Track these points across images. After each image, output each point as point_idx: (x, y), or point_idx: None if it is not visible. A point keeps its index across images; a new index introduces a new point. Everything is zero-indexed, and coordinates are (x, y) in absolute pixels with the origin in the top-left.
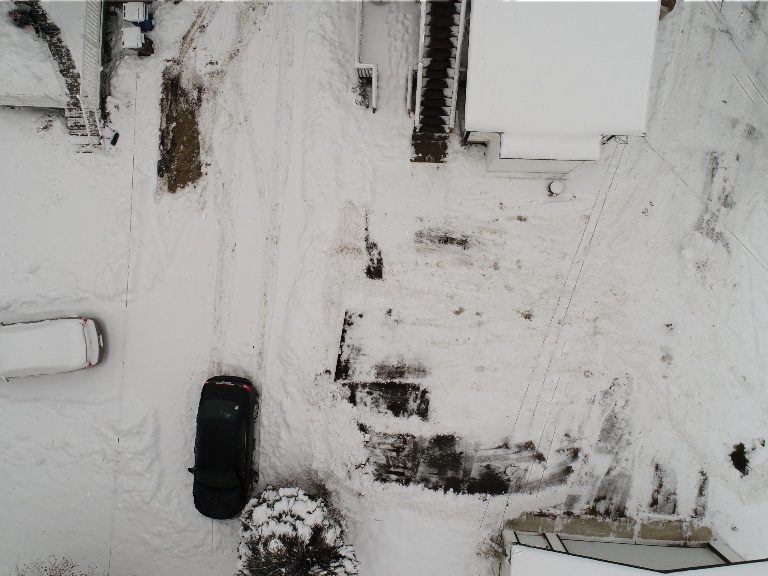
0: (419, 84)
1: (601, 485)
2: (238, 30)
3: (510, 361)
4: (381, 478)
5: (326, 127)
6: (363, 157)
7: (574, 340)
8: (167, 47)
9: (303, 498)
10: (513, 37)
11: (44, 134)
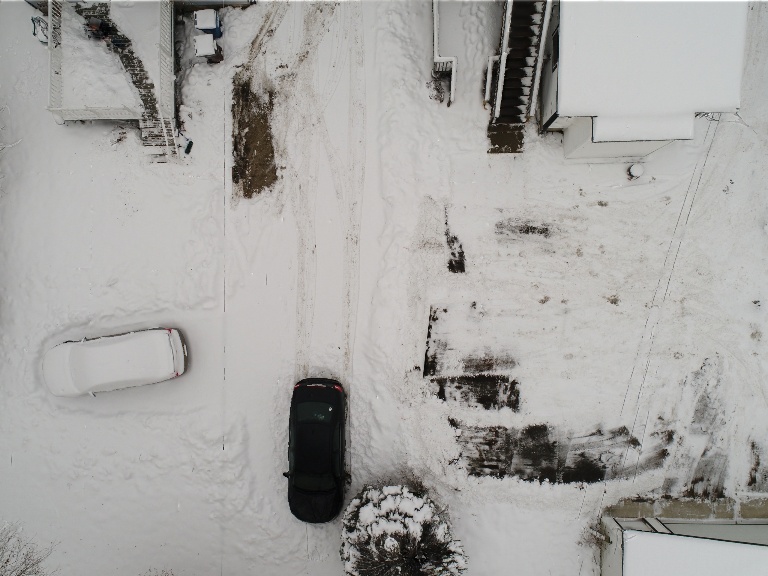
0: (502, 74)
1: (698, 466)
2: (306, 32)
3: (599, 347)
4: (475, 472)
5: (402, 123)
6: (440, 151)
7: (662, 322)
8: (236, 53)
9: (408, 495)
10: (604, 20)
11: (117, 147)
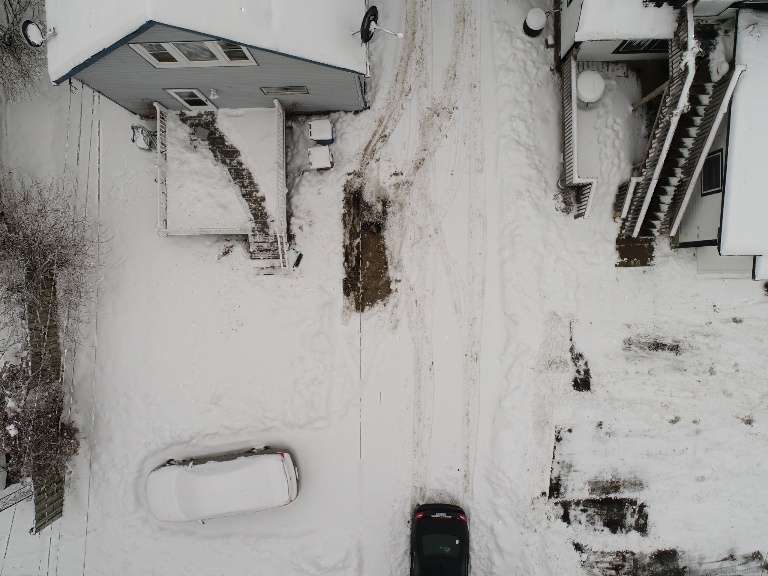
0: (649, 199)
1: None
2: (422, 138)
3: (732, 469)
4: None
5: (527, 237)
6: (565, 265)
7: None
8: (348, 160)
9: None
10: None
11: (223, 259)
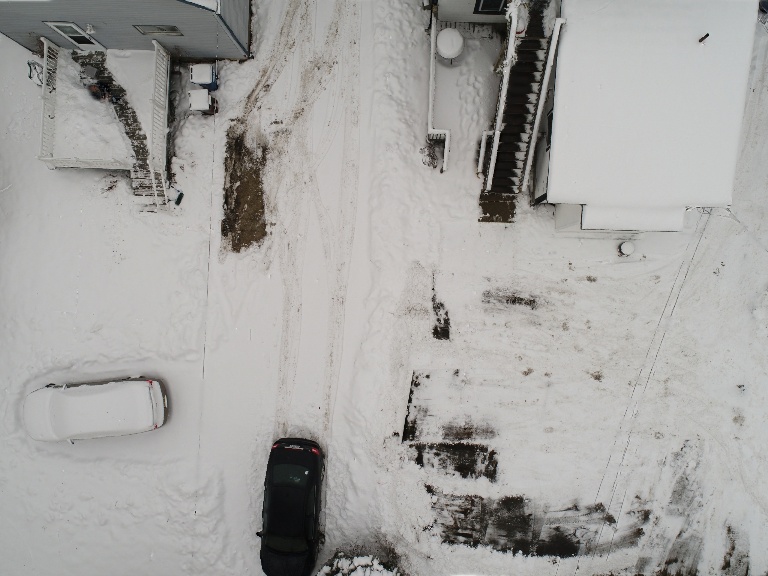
0: (495, 151)
1: (672, 547)
2: (303, 89)
3: (580, 422)
4: (449, 540)
5: (393, 188)
6: (430, 217)
7: (645, 401)
8: (232, 107)
9: (378, 568)
10: (599, 111)
11: (108, 194)
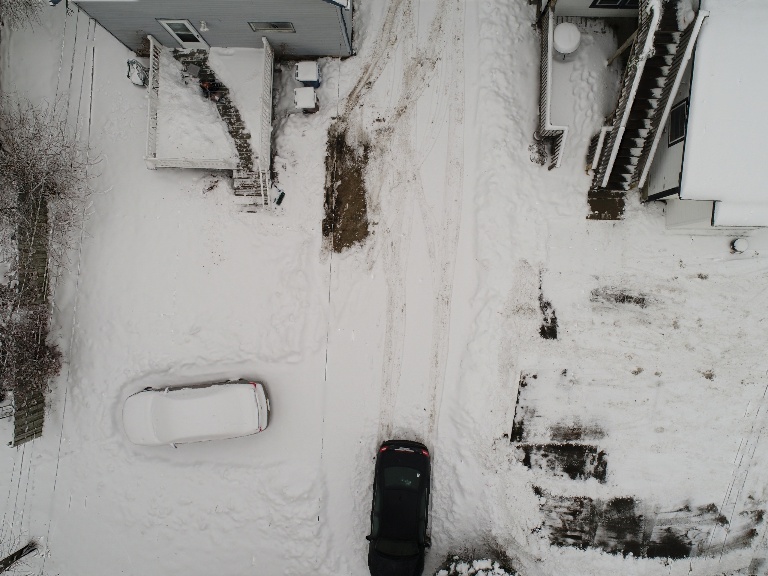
0: (617, 147)
1: None
2: (406, 86)
3: (691, 422)
4: (557, 542)
5: (501, 185)
6: (538, 215)
7: (757, 400)
8: (333, 104)
9: (499, 571)
10: (738, 105)
11: (208, 194)
